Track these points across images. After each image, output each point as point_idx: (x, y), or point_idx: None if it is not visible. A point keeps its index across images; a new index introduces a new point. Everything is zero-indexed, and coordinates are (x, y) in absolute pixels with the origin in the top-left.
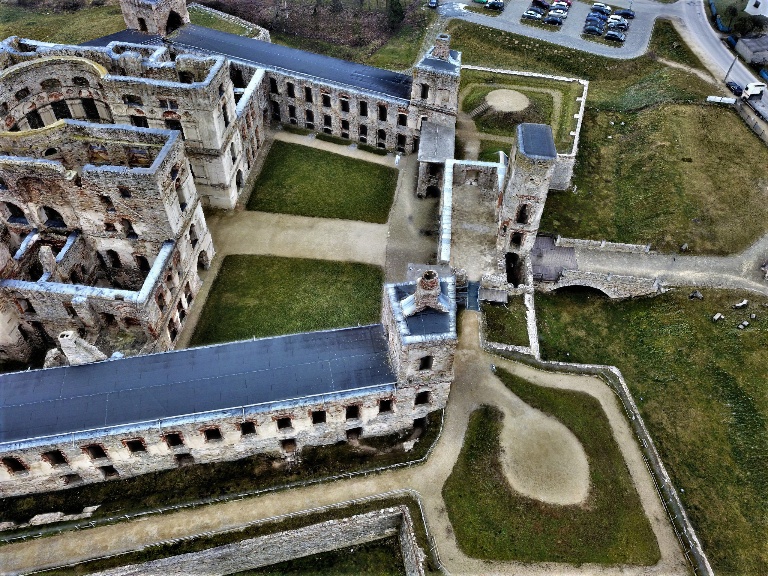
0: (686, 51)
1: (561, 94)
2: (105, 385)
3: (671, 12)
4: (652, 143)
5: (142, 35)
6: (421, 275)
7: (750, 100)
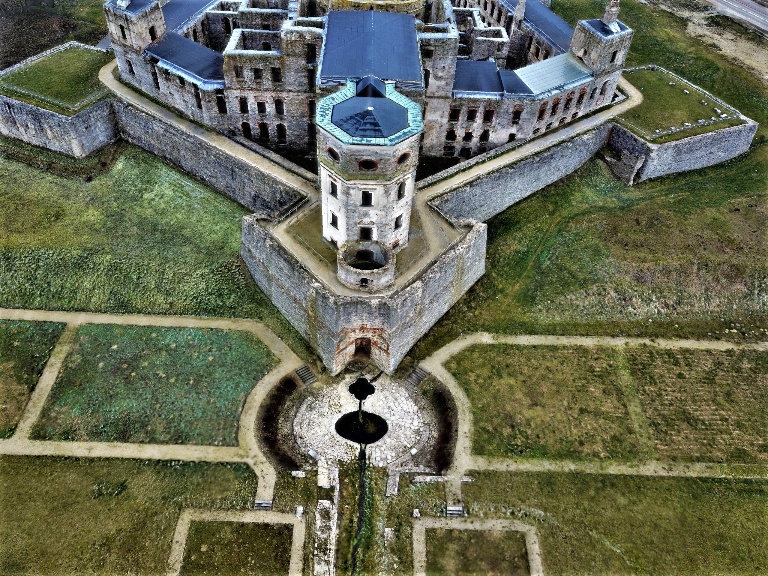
0: None
1: None
2: (530, 8)
3: None
4: None
5: (165, 39)
6: None
7: None
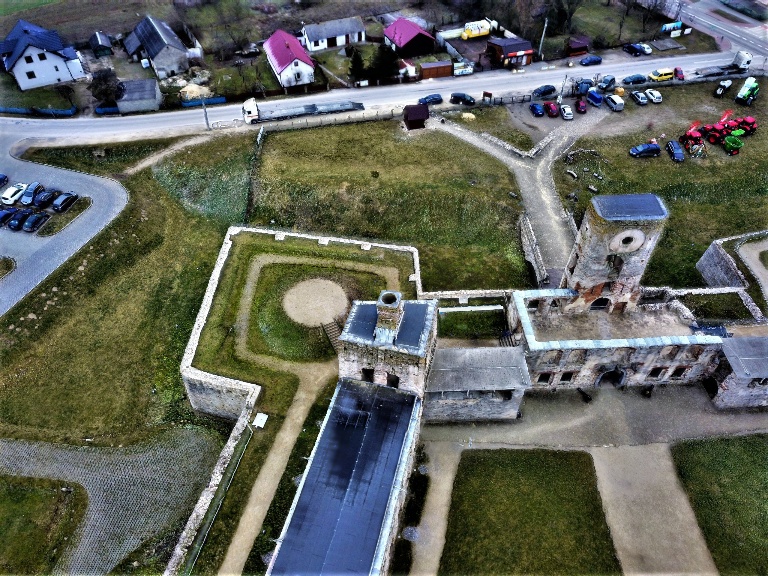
0: (125, 146)
1: (263, 255)
2: None
3: (5, 143)
4: (337, 197)
5: None
6: (750, 364)
7: (260, 117)
